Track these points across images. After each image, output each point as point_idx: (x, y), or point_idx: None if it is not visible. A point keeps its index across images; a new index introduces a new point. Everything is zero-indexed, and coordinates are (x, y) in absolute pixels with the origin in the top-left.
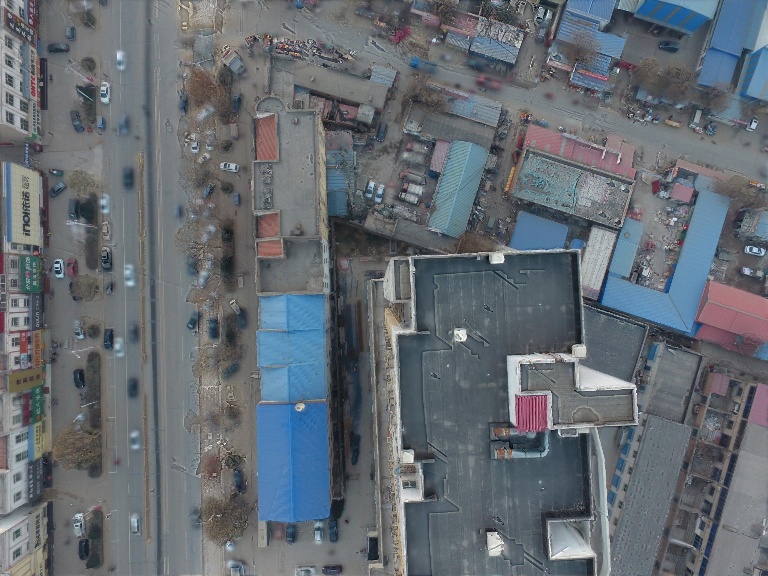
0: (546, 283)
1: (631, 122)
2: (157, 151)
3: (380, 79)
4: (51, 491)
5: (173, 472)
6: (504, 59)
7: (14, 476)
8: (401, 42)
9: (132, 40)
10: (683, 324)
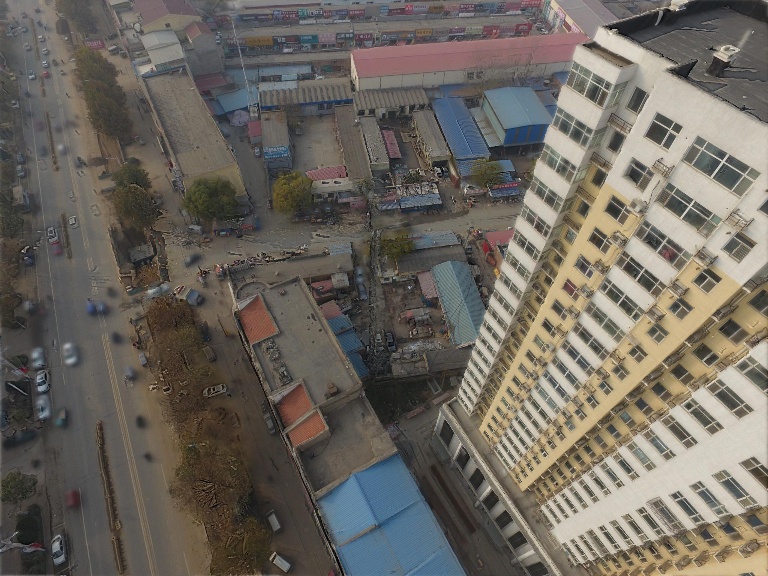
0: (734, 24)
1: None
2: (119, 414)
3: (339, 252)
4: None
5: None
6: (432, 203)
7: None
8: (341, 226)
9: (71, 322)
10: None
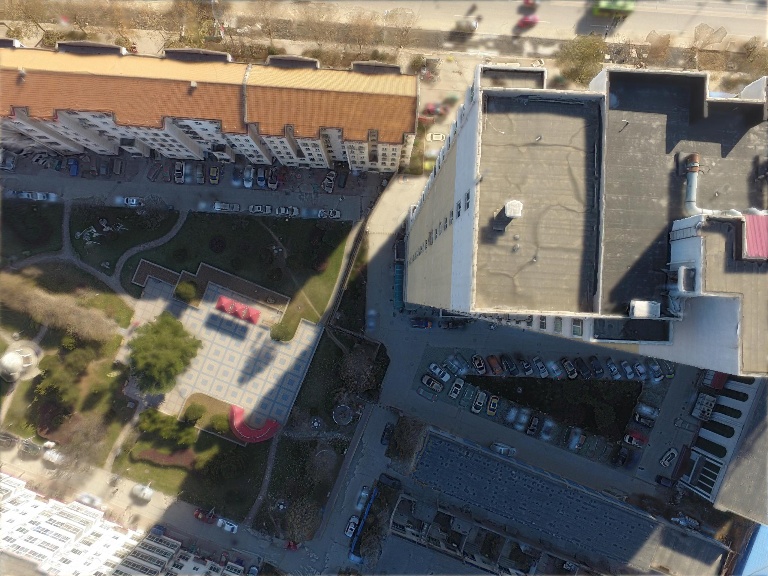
0: None
1: None
2: None
3: None
4: None
5: (612, 15)
6: None
7: None
8: None
9: None
10: (749, 574)
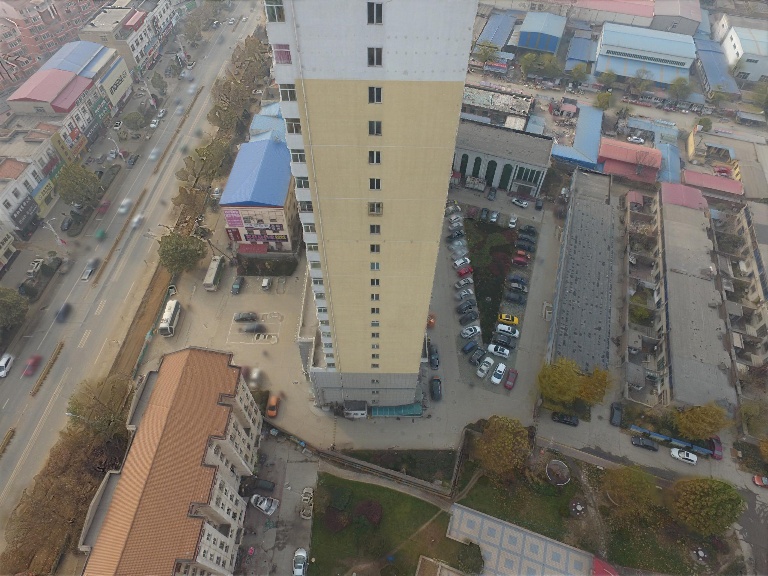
0: None
1: (528, 89)
2: None
3: None
4: (25, 244)
5: (144, 239)
6: None
7: (15, 189)
8: None
9: (217, 53)
10: (589, 160)
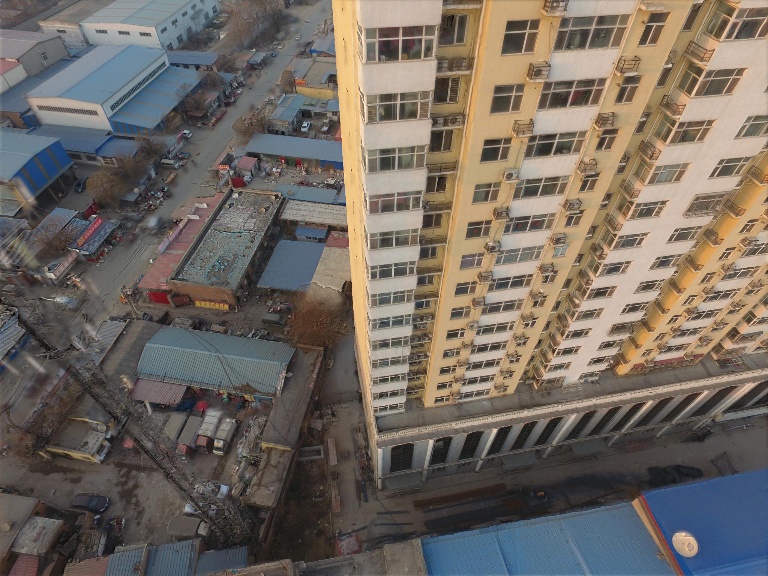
0: None
1: (161, 207)
2: None
3: None
4: None
5: None
6: None
7: None
8: None
9: None
10: None
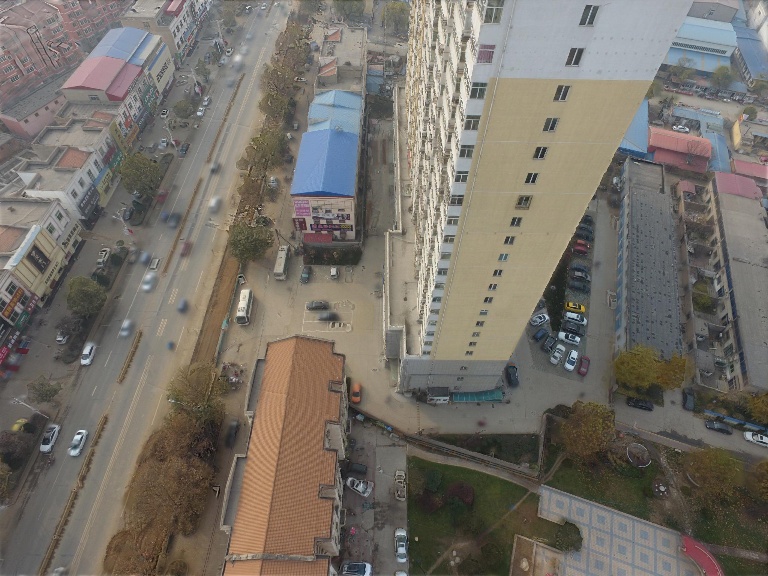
0: None
1: None
2: (254, 73)
3: None
4: (89, 234)
5: (206, 228)
6: None
7: (81, 179)
8: None
9: (253, 39)
10: (639, 149)
